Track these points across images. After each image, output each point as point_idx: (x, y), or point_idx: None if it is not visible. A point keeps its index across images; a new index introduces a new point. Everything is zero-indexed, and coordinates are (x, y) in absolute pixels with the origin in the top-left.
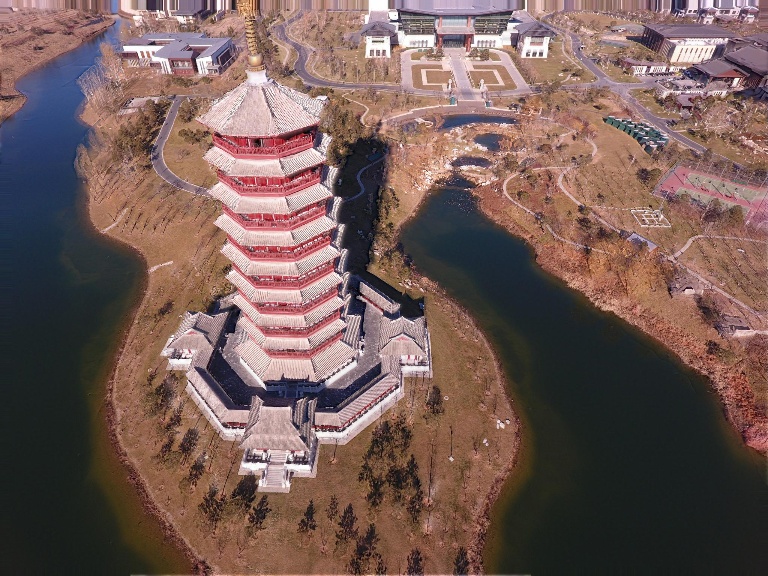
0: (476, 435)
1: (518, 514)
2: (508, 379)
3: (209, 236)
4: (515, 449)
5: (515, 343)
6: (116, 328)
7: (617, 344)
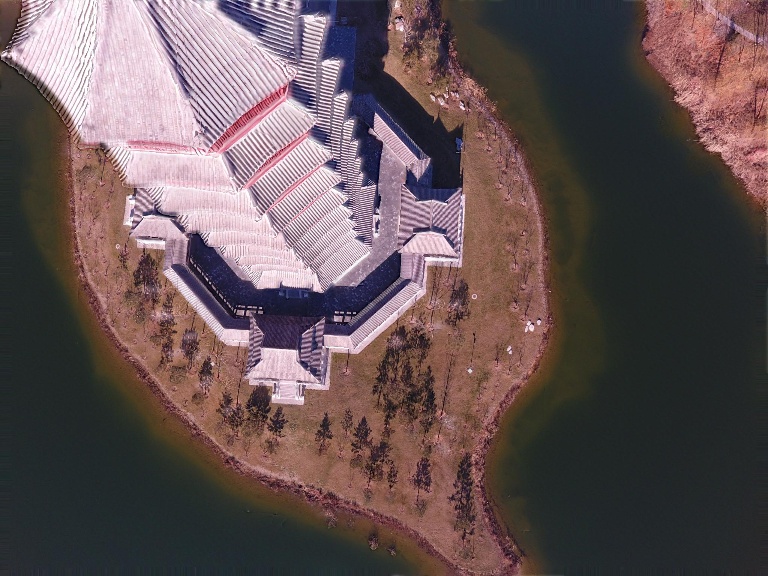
0: (501, 343)
1: (526, 418)
2: (552, 260)
3: None
4: (539, 354)
5: (573, 202)
6: (52, 166)
7: (702, 175)
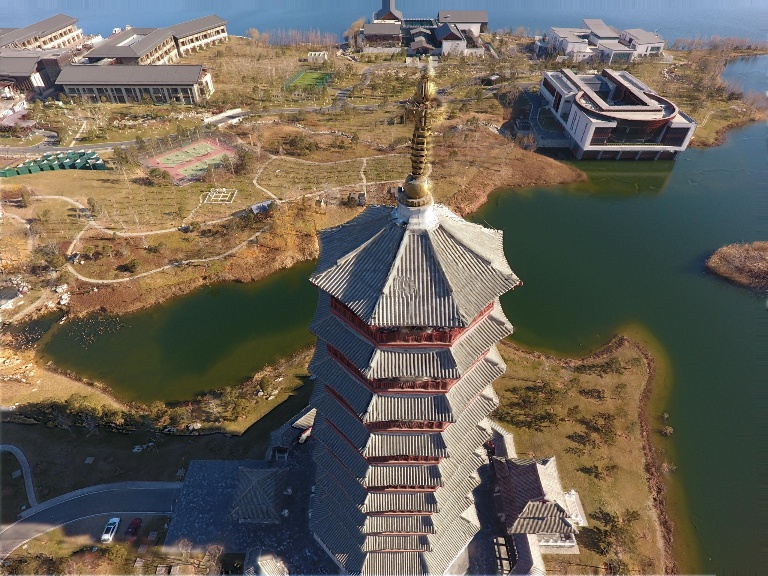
0: None
1: (520, 338)
2: None
3: None
4: None
5: None
6: None
7: None
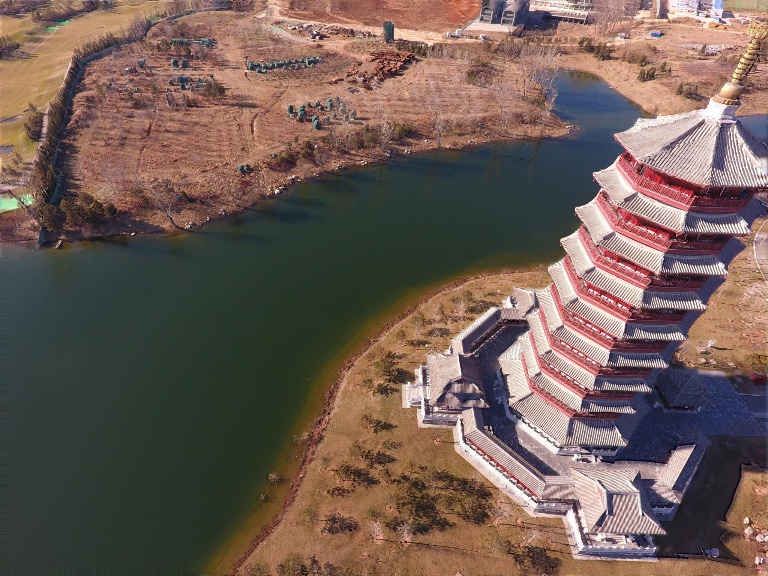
0: None
1: None
2: None
3: None
4: None
5: None
6: (539, 263)
7: None
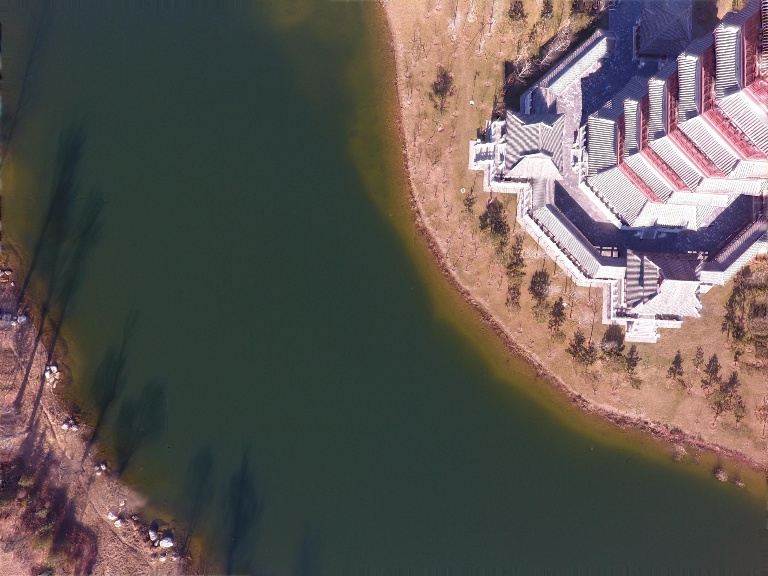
0: None
1: None
2: None
3: None
4: None
5: None
6: (379, 113)
7: None
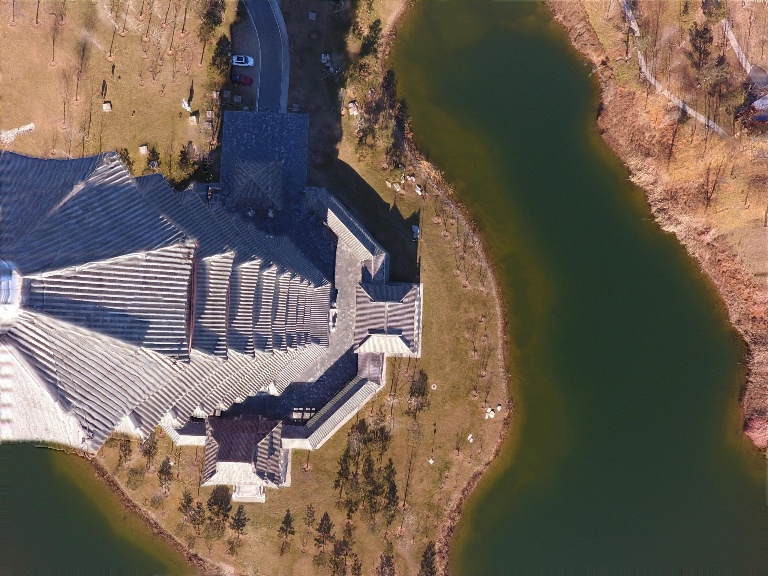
0: (461, 432)
1: (489, 502)
2: (511, 344)
3: (74, 70)
4: (500, 439)
5: (531, 284)
6: None
7: (660, 242)
